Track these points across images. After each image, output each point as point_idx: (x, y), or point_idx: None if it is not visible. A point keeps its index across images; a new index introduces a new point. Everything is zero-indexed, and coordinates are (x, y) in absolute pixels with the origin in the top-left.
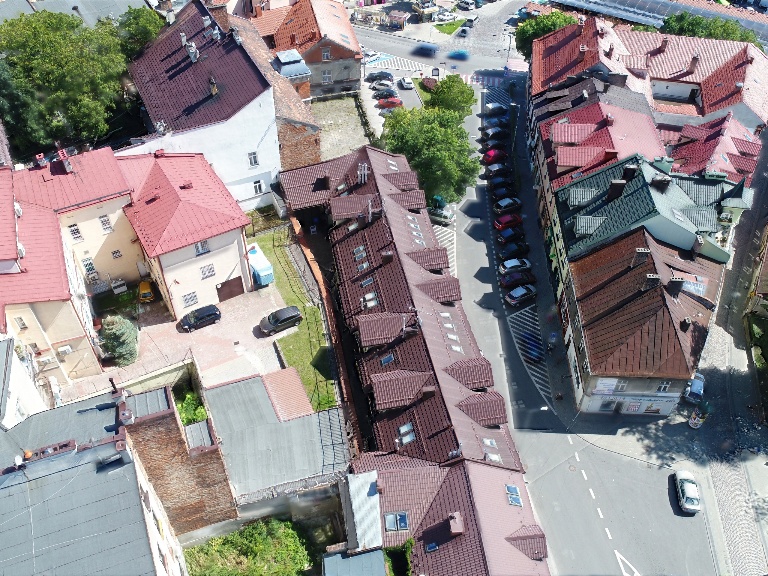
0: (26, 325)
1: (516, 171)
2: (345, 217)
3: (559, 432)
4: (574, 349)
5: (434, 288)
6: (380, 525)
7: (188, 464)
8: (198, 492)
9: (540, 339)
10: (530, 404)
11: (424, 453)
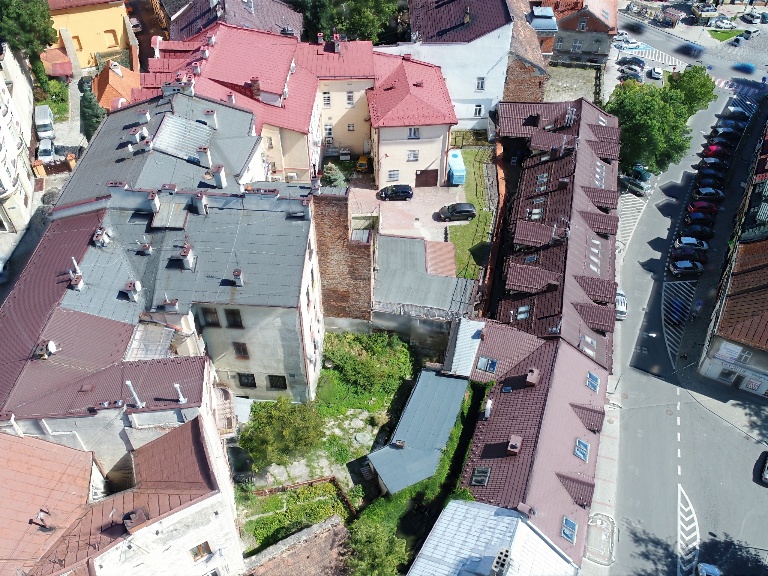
0: (273, 145)
1: (732, 169)
2: (541, 149)
3: (670, 382)
4: (714, 319)
5: (594, 218)
6: (473, 362)
7: (347, 251)
8: (348, 281)
9: (688, 308)
10: (653, 353)
11: (531, 328)
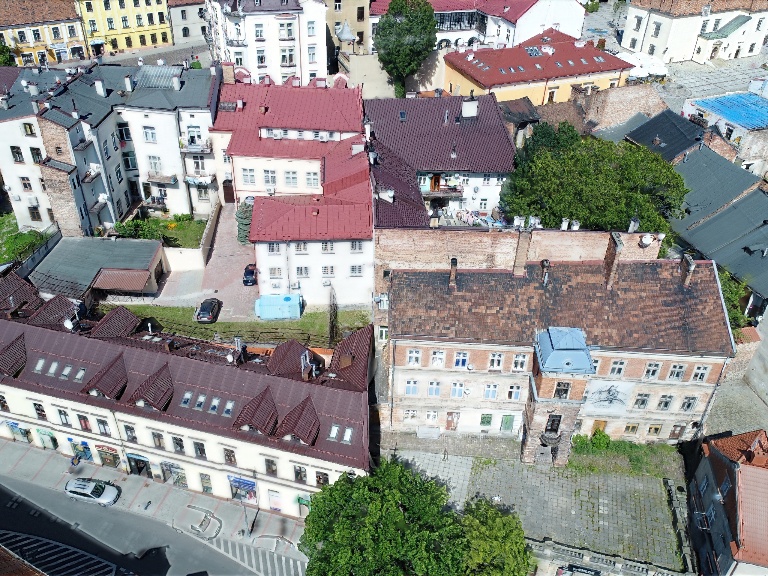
0: None
1: None
2: None
3: None
4: None
5: None
6: None
7: None
8: None
9: None
10: (4, 512)
11: None
